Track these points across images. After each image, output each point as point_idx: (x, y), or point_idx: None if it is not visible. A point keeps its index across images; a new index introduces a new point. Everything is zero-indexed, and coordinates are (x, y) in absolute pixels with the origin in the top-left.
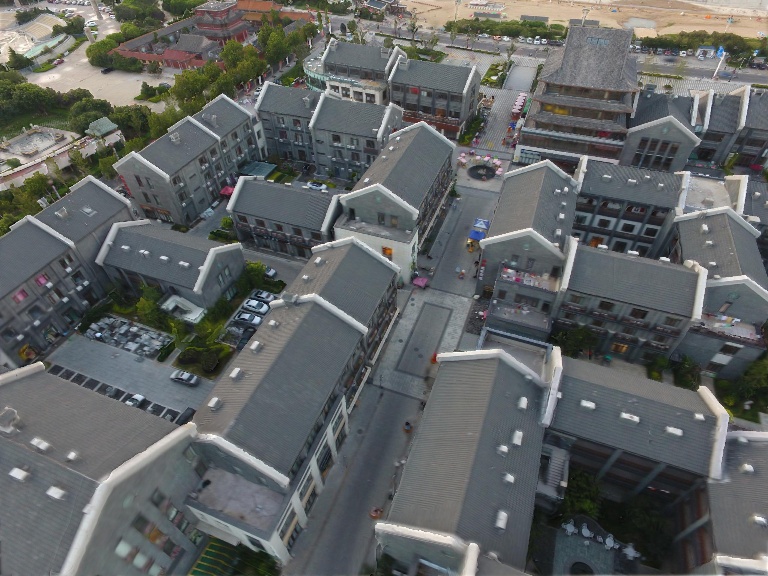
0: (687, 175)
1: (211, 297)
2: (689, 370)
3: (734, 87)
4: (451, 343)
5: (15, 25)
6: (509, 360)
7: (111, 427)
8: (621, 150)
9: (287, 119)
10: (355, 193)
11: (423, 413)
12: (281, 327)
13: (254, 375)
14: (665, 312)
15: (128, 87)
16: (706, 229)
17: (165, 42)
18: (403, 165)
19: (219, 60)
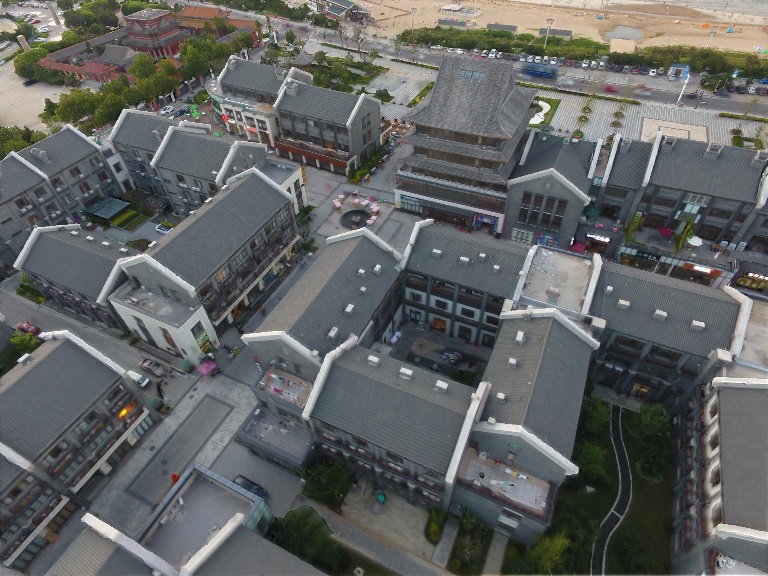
0: (529, 257)
1: None
2: (472, 528)
3: (699, 116)
4: (209, 456)
5: None
6: (128, 550)
7: None
8: (505, 203)
9: (141, 152)
10: (128, 261)
11: None
12: None
13: None
14: (417, 464)
15: (41, 102)
16: (519, 339)
17: (100, 51)
18: (201, 226)
19: None
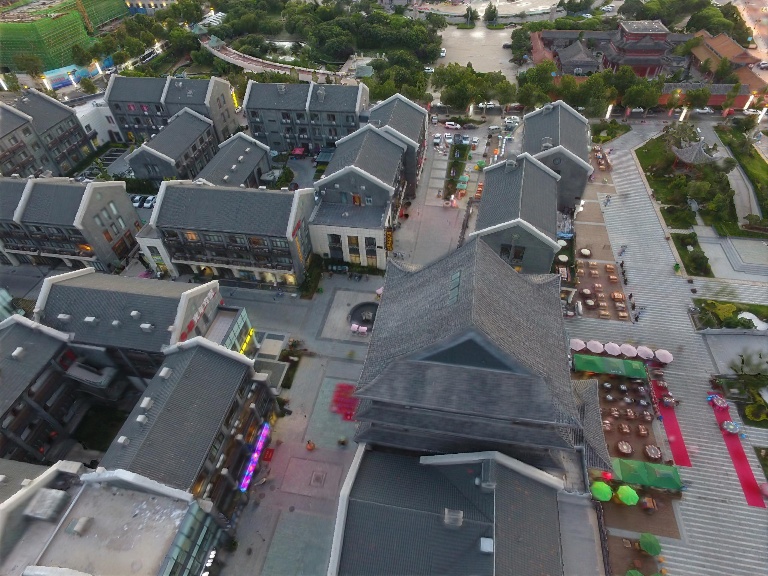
0: (115, 471)
1: (139, 172)
2: None
3: None
4: None
5: None
6: None
7: None
8: None
9: None
10: None
11: None
12: None
13: None
14: None
15: (484, 64)
16: None
17: (589, 45)
18: (214, 195)
19: None
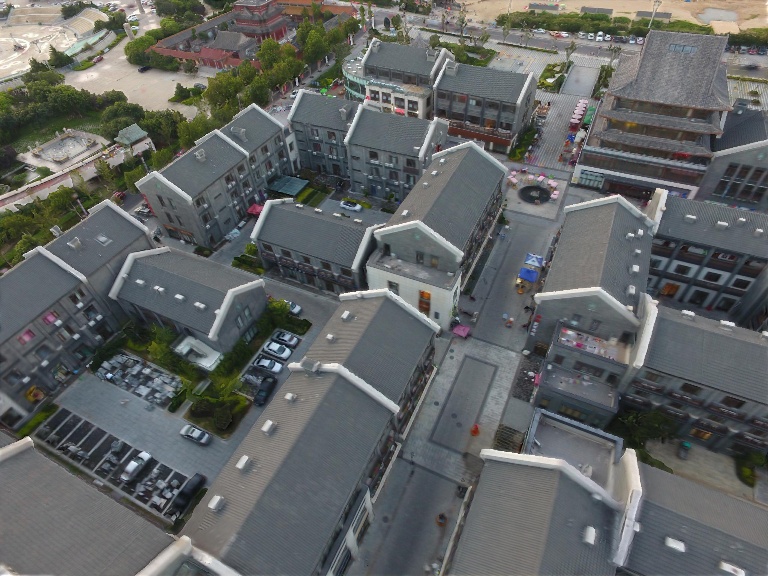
0: None
1: (228, 341)
2: None
3: None
4: (495, 410)
5: (61, 19)
6: (573, 475)
7: (91, 541)
8: (702, 176)
9: (321, 131)
10: (391, 229)
11: (462, 532)
12: (298, 403)
13: (263, 469)
14: None
15: (163, 87)
16: None
17: (203, 38)
18: (447, 195)
19: (256, 59)
